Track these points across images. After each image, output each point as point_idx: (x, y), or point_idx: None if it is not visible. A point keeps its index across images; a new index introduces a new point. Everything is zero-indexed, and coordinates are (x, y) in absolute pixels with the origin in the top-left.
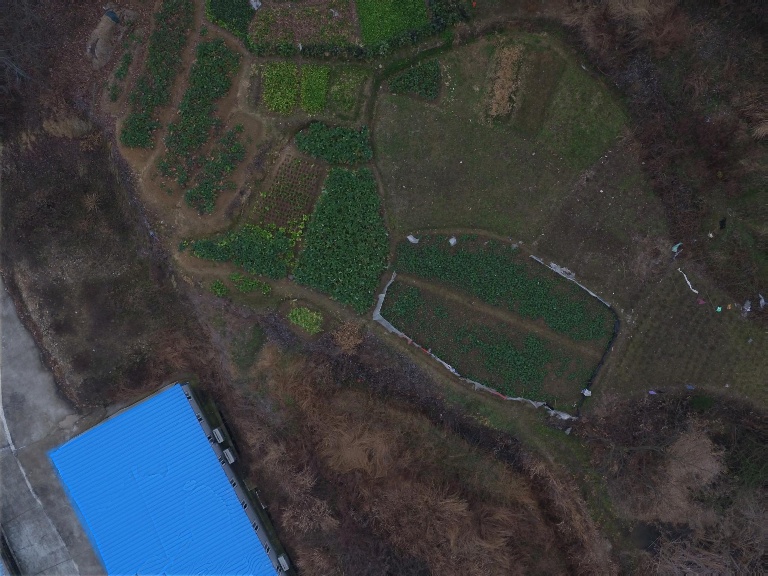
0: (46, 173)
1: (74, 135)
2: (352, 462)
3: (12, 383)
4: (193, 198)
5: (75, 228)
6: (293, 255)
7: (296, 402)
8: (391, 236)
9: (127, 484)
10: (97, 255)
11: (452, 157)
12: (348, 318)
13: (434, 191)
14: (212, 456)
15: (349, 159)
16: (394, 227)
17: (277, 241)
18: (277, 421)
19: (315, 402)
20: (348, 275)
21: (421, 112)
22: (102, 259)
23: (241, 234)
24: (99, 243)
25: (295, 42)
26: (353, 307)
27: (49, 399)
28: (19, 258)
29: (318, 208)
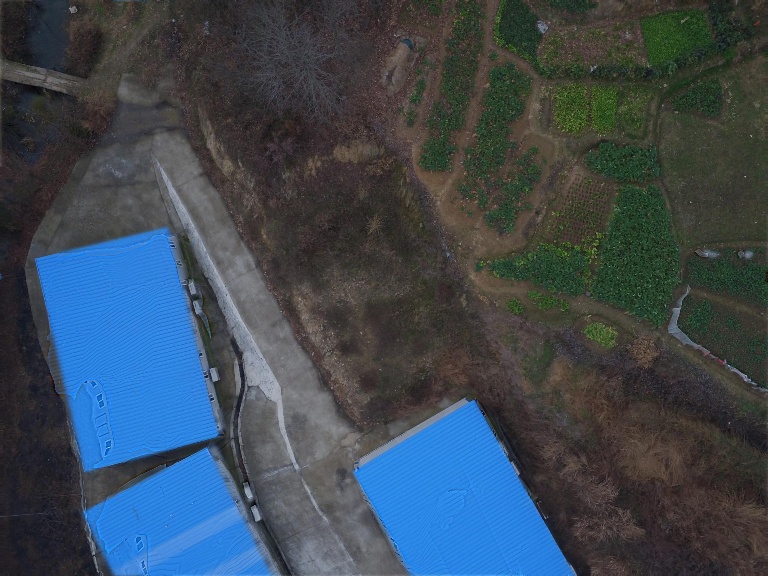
0: (325, 197)
1: (360, 160)
2: (648, 471)
3: (293, 403)
4: (494, 220)
5: (357, 250)
6: (590, 272)
7: (593, 415)
8: (681, 251)
9: (467, 501)
10: (380, 276)
11: (736, 172)
12: (643, 332)
13: (720, 206)
14: (510, 470)
15: (639, 177)
16: (682, 242)
17: (573, 259)
18: (576, 434)
19: (609, 414)
20: (646, 290)
21: (706, 129)
22: (384, 280)
23: (537, 253)
24: (381, 265)
25: (586, 64)
26: (649, 321)
27: (330, 418)
28: (300, 281)
29: (612, 226)
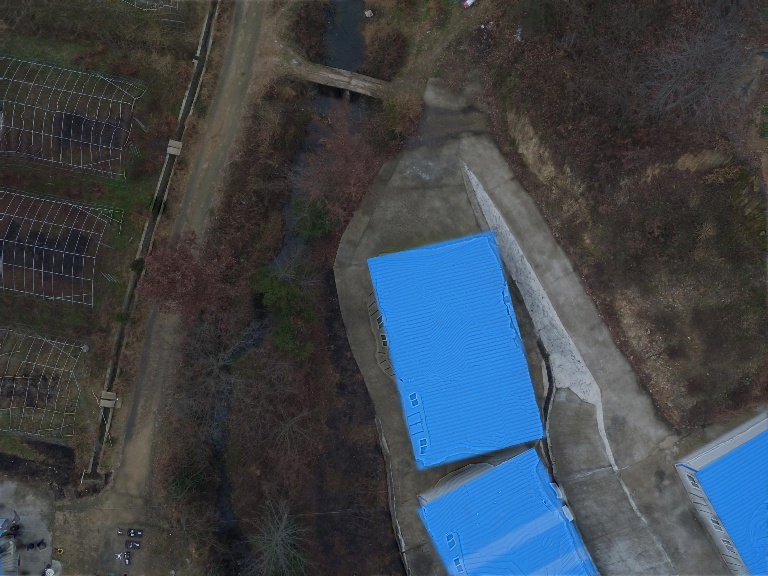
0: (653, 204)
1: (698, 168)
2: None
3: (613, 406)
4: None
5: (685, 257)
6: None
7: None
8: None
9: None
10: (708, 283)
11: None
12: None
13: None
14: None
15: None
16: None
17: None
18: None
19: None
20: None
21: None
22: (712, 286)
23: None
24: (709, 271)
25: None
26: None
27: (649, 421)
28: (627, 286)
29: None
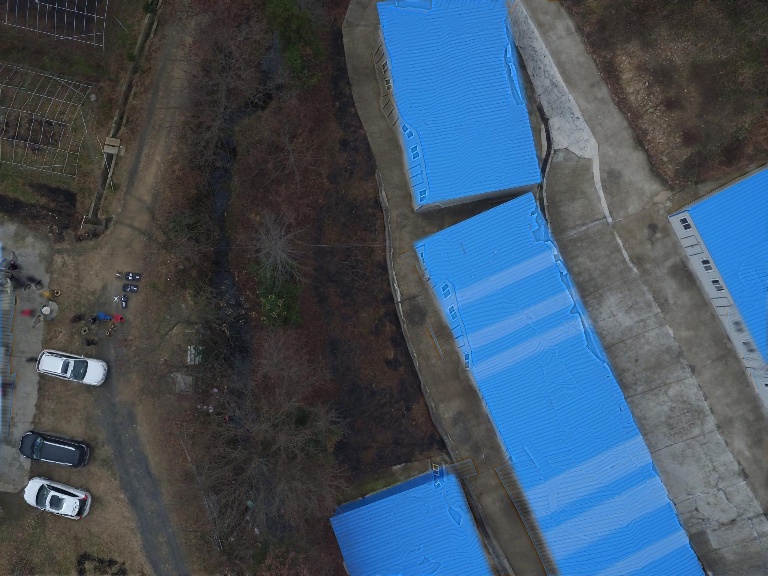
0: None
1: None
2: None
3: (609, 160)
4: None
5: (684, 13)
6: None
7: None
8: None
9: None
10: (705, 38)
11: None
12: None
13: None
14: None
15: None
16: None
17: None
18: None
19: None
20: None
21: None
22: (709, 42)
23: None
24: (707, 27)
25: None
26: None
27: (644, 176)
28: (627, 40)
29: None
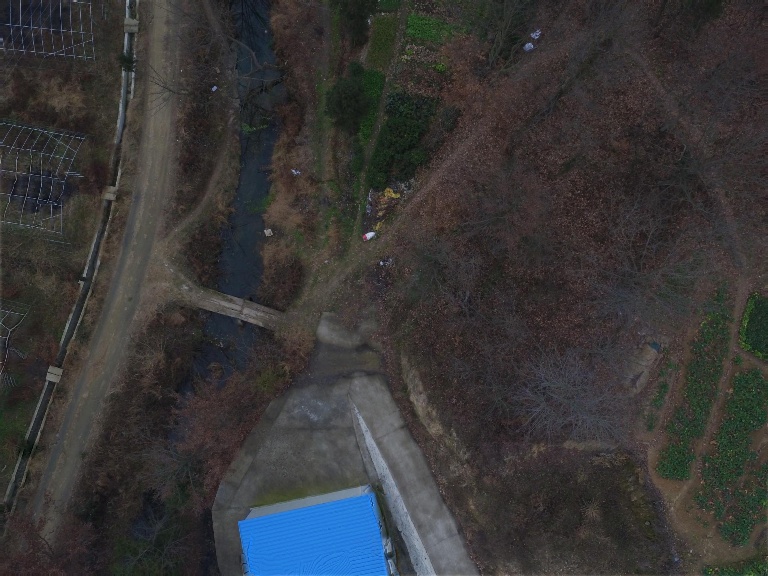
0: (541, 476)
1: (586, 448)
2: None
3: None
4: (730, 533)
5: (570, 533)
6: None
7: None
8: None
9: None
10: (593, 562)
11: None
12: None
13: None
14: None
15: None
16: None
17: None
18: None
19: None
20: None
21: None
22: (597, 566)
23: (766, 564)
24: (595, 550)
25: None
26: None
27: None
28: (510, 559)
29: None
